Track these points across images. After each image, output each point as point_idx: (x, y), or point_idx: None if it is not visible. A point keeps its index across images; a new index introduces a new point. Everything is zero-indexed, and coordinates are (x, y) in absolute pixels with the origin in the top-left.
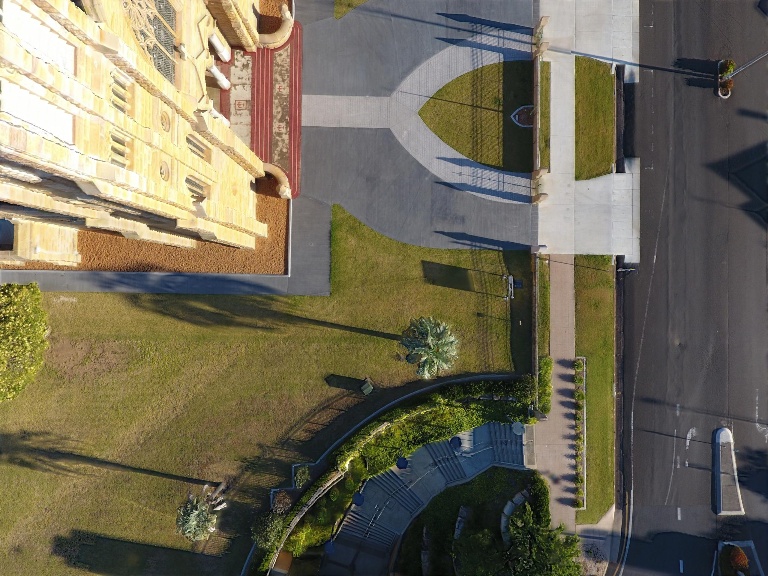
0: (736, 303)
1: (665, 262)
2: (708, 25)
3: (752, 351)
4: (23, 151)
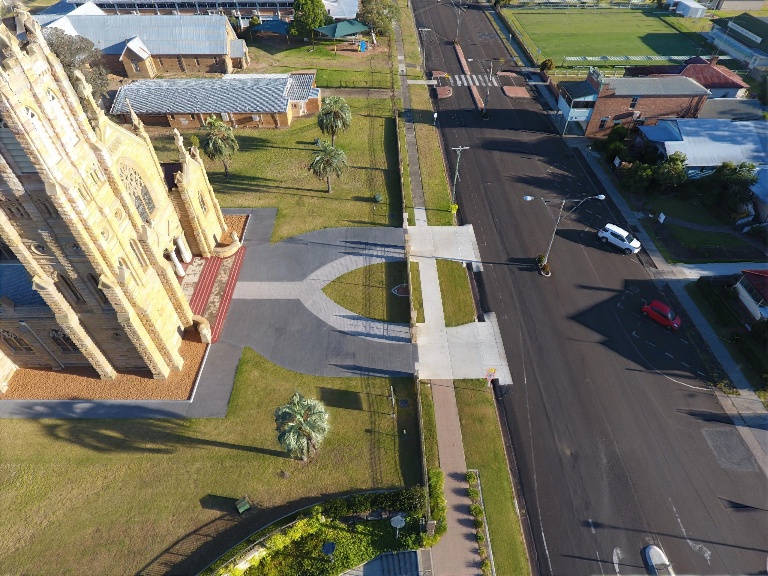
0: (612, 413)
1: (535, 382)
2: (523, 242)
3: (646, 458)
4: (28, 133)
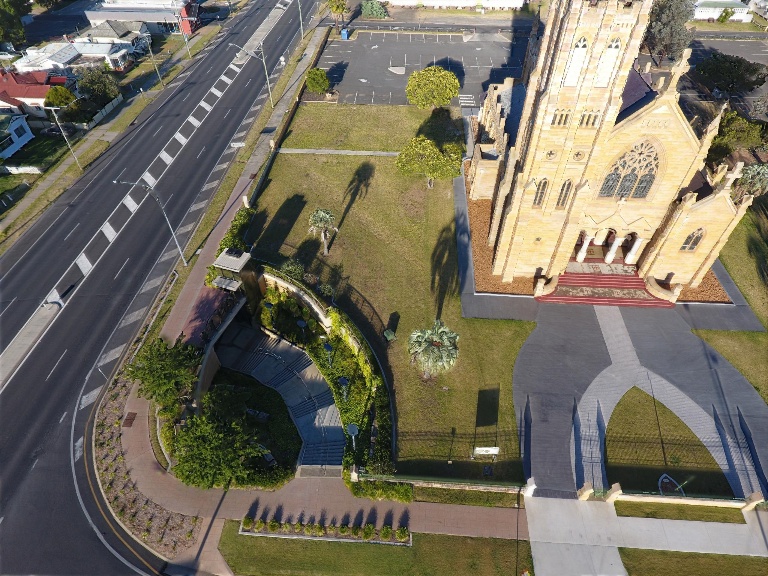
0: None
1: None
2: None
3: None
4: (561, 51)
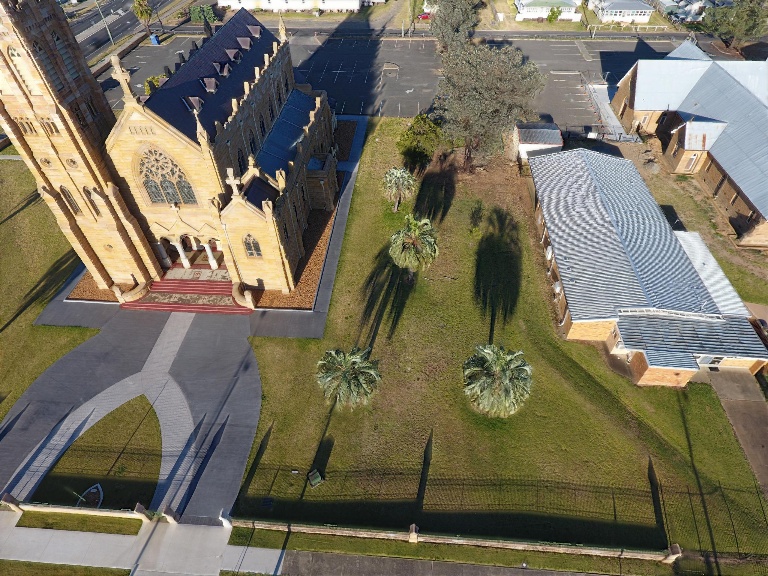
0: None
1: None
2: None
3: None
4: None
